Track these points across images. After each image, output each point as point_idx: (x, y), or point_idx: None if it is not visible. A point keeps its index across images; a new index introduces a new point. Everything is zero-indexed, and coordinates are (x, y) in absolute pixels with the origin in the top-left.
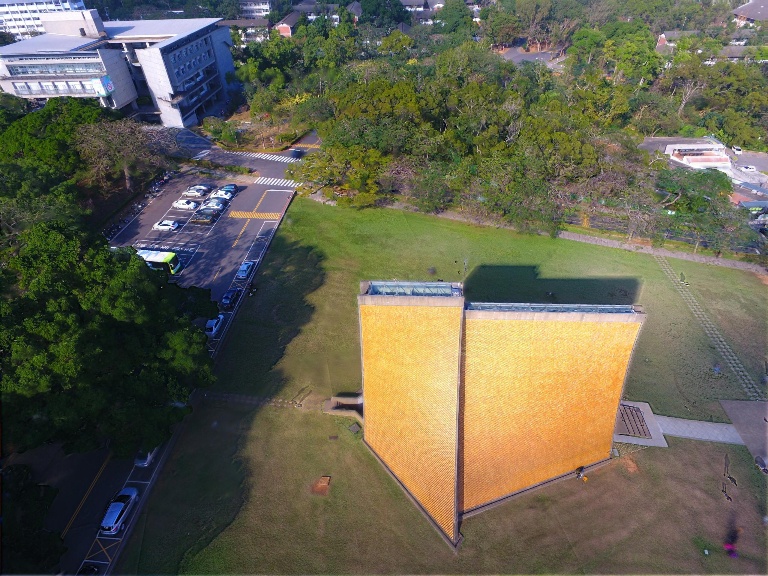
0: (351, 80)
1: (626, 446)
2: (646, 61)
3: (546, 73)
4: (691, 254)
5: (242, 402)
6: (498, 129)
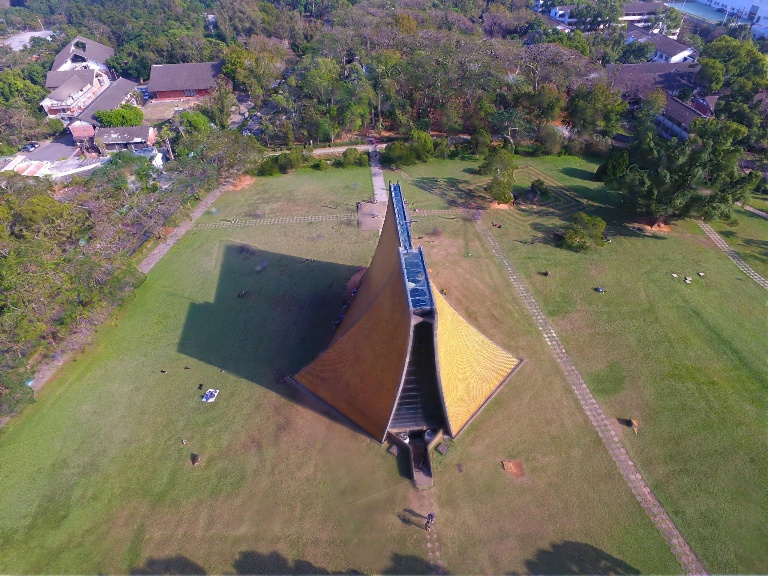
0: None
1: None
2: None
3: None
4: (193, 211)
5: None
6: None
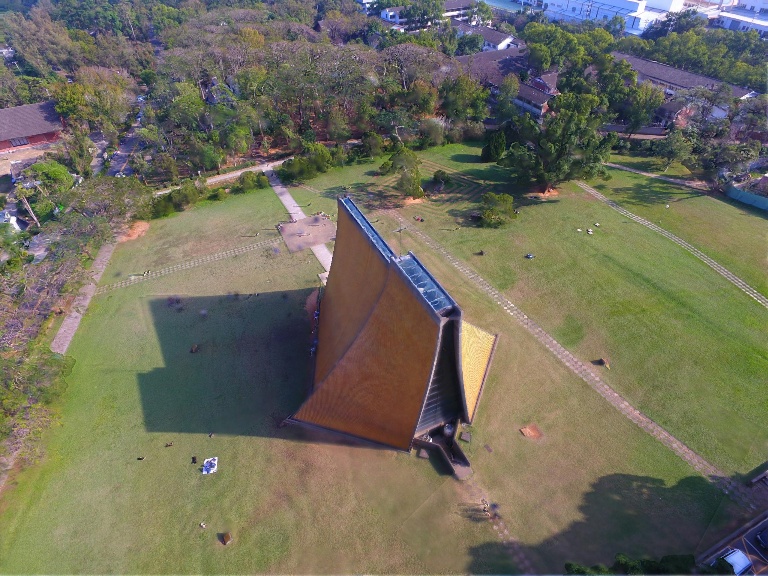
0: None
1: None
2: None
3: None
4: None
5: (534, 570)
6: None
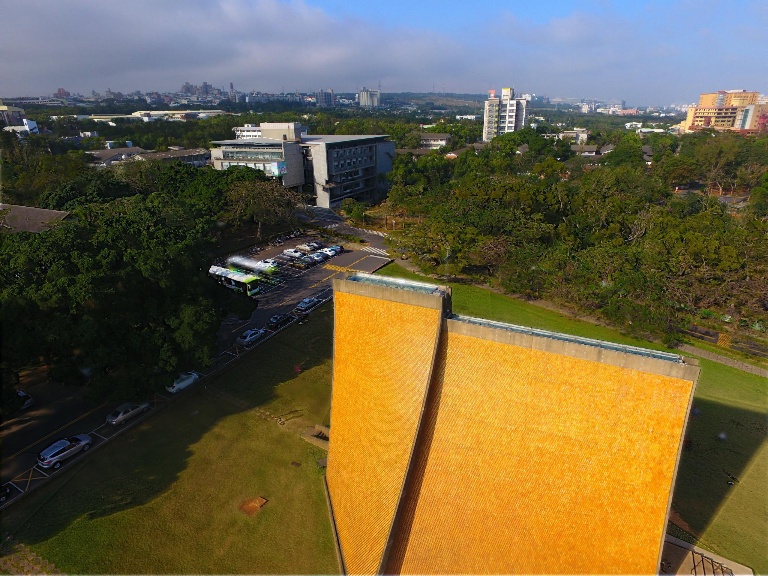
0: None
1: None
2: None
3: (716, 205)
4: None
5: (232, 403)
6: (620, 227)
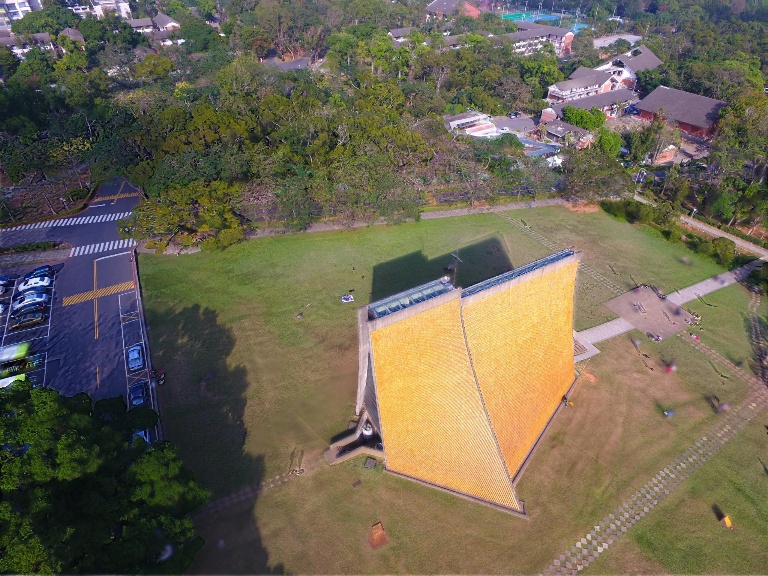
0: (124, 114)
1: (579, 364)
2: (396, 56)
3: (321, 78)
4: (517, 203)
5: (236, 502)
6: (327, 135)
